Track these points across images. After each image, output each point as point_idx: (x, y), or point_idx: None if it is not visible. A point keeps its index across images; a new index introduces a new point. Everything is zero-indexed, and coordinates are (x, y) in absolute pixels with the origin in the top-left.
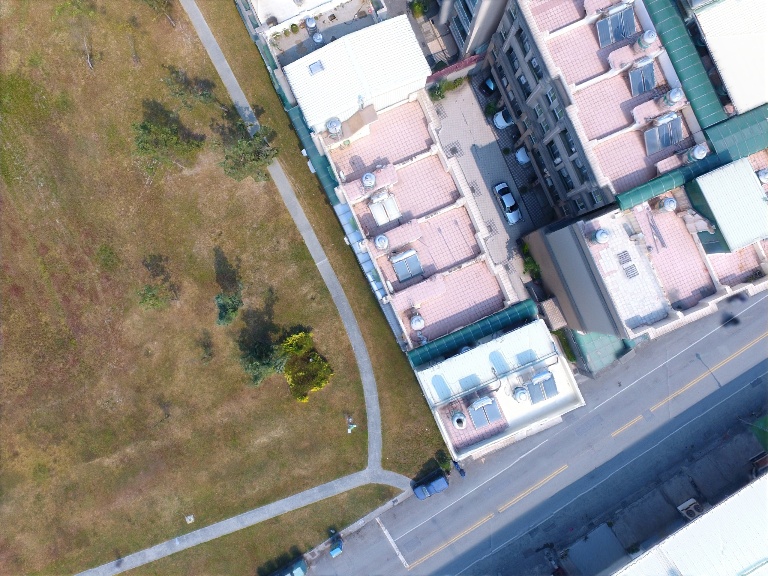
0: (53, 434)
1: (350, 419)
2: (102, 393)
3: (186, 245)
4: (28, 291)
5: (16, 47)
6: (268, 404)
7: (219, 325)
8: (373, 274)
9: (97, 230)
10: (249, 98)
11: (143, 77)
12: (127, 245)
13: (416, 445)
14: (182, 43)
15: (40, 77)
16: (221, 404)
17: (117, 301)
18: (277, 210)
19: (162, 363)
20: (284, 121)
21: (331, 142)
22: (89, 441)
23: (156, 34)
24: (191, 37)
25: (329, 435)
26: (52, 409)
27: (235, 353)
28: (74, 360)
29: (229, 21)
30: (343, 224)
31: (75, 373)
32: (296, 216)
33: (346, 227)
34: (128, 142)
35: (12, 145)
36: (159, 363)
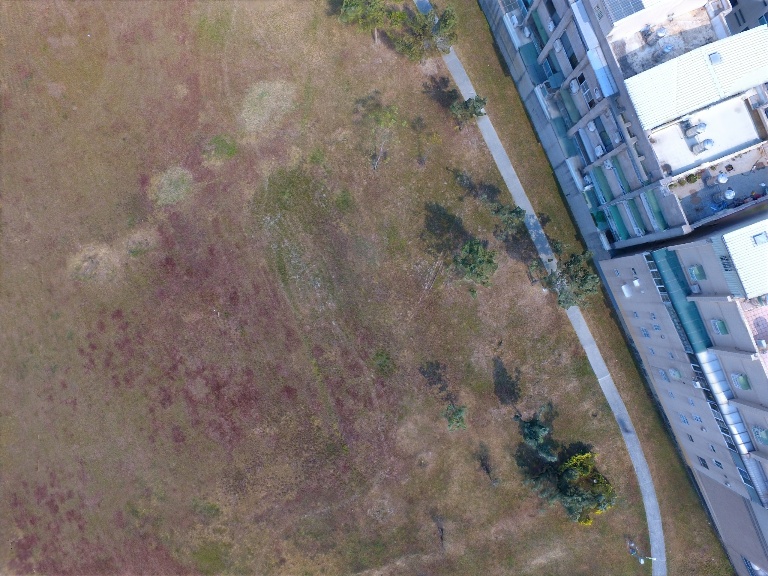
0: (321, 542)
1: (632, 544)
2: (373, 502)
3: (464, 354)
4: (301, 393)
5: (298, 143)
6: (546, 523)
7: (496, 438)
8: (762, 437)
9: (374, 334)
10: (535, 206)
11: (427, 179)
12: (404, 351)
13: (702, 575)
14: (468, 146)
15: (321, 175)
16: (496, 520)
17: (392, 408)
18: (560, 322)
19: (436, 474)
20: (570, 231)
21: (749, 307)
22: (358, 551)
23: (441, 136)
24: (477, 140)
25: (610, 560)
26: (321, 516)
27: (512, 468)
28: (345, 467)
29: (517, 126)
30: (707, 372)
31: (346, 480)
32: (579, 329)
33: (710, 376)
34: (408, 245)
35: (290, 243)
36: (433, 474)
